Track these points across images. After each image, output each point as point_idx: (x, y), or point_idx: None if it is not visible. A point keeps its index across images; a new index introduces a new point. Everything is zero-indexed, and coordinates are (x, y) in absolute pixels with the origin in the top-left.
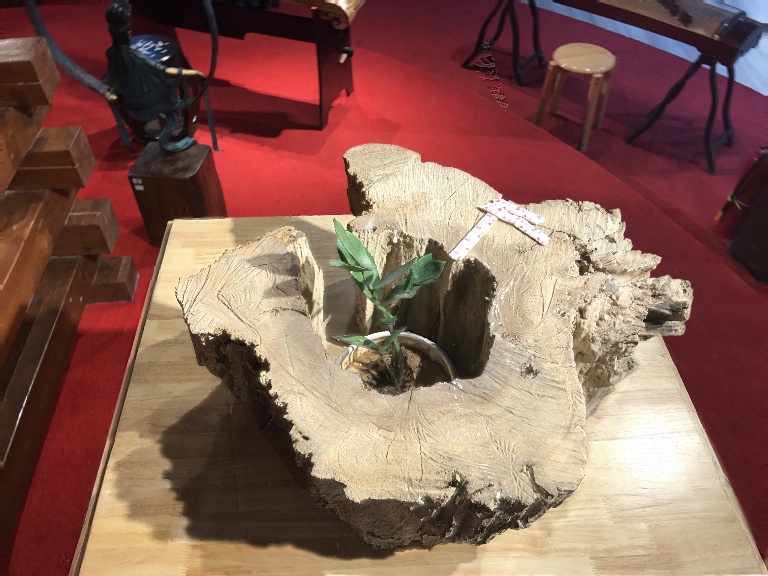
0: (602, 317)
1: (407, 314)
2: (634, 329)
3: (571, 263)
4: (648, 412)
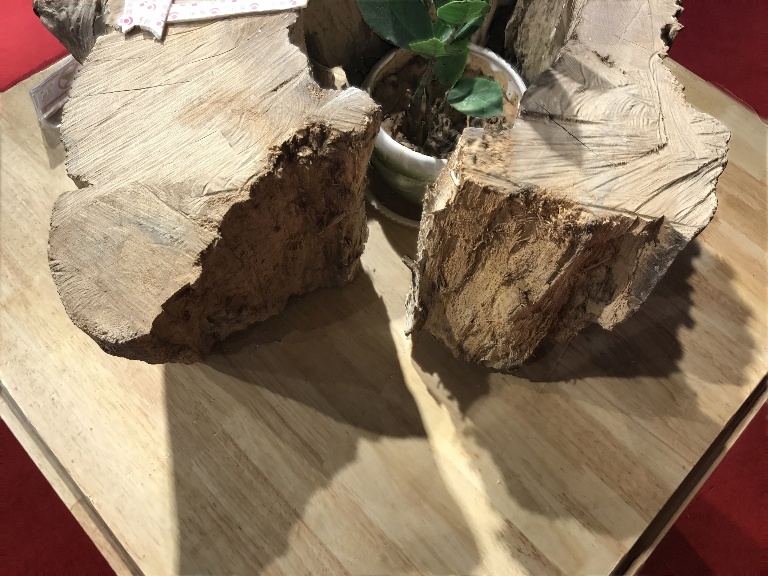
0: None
1: None
2: None
3: None
4: None
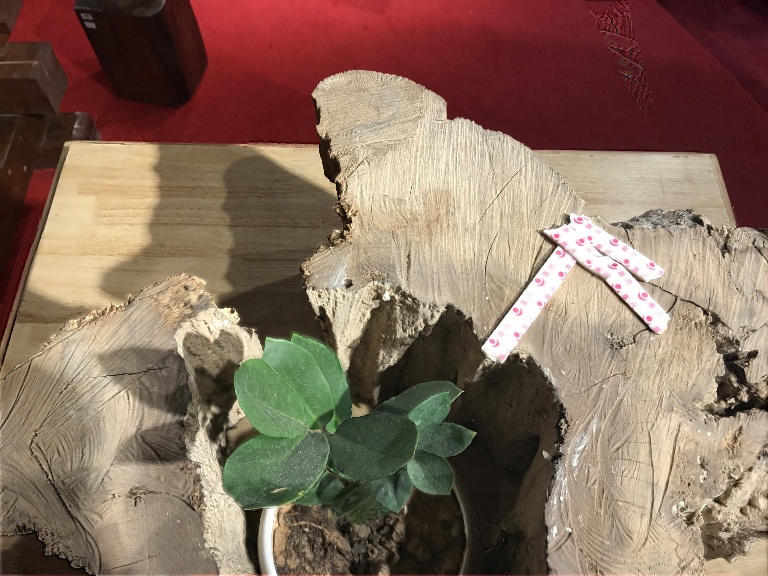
0: (755, 502)
1: (403, 372)
2: None
3: (708, 384)
4: None
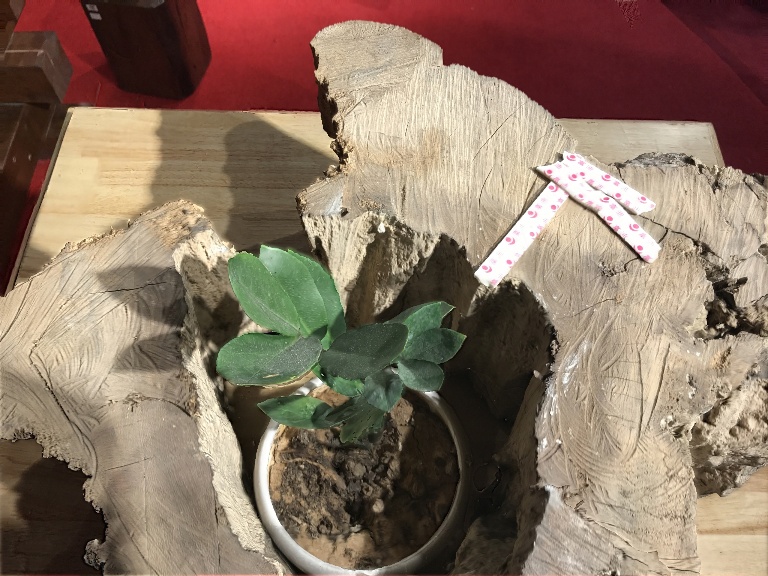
0: (744, 422)
1: None
2: None
3: (698, 309)
4: (752, 488)
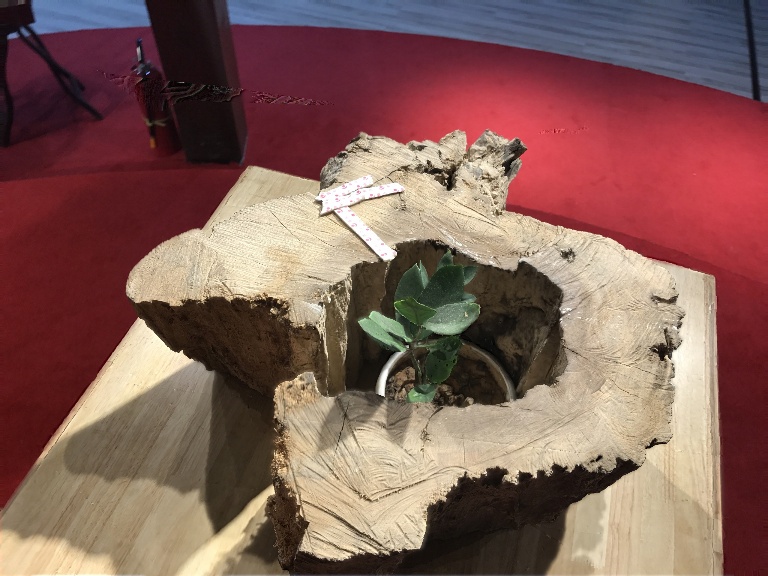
0: (494, 196)
1: None
2: (505, 186)
3: (438, 183)
4: None
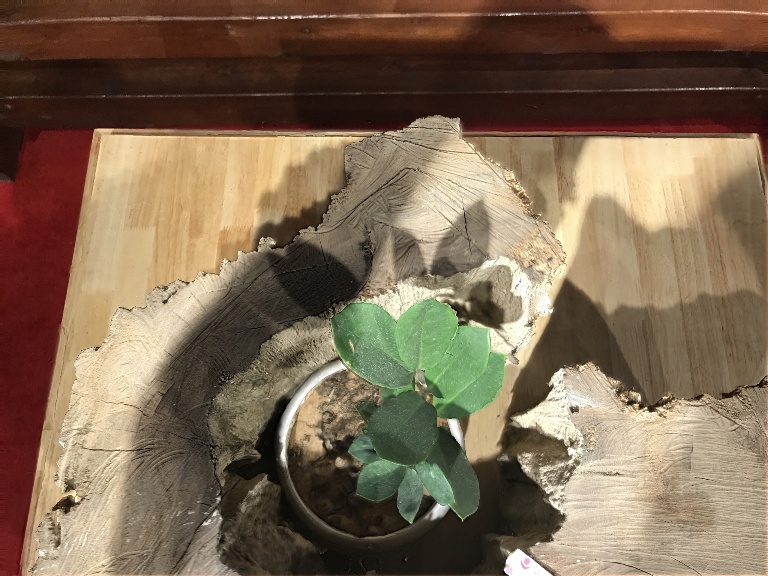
0: None
1: (524, 483)
2: None
3: None
4: None
